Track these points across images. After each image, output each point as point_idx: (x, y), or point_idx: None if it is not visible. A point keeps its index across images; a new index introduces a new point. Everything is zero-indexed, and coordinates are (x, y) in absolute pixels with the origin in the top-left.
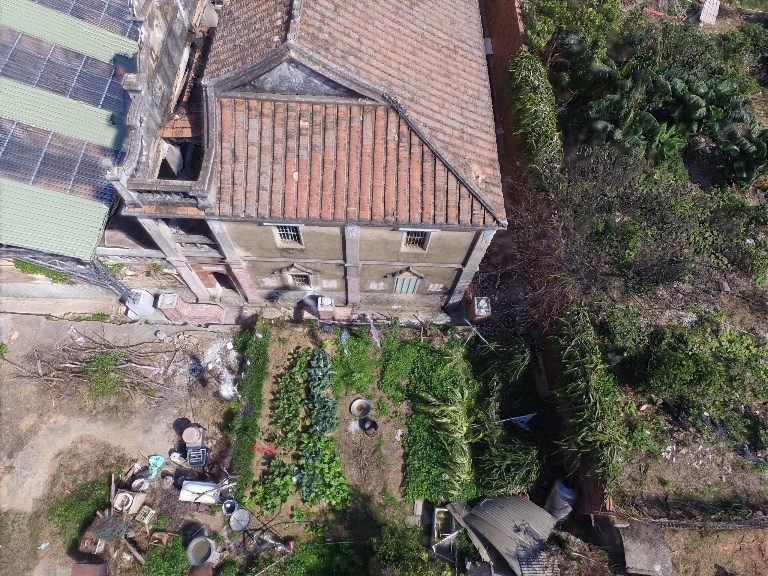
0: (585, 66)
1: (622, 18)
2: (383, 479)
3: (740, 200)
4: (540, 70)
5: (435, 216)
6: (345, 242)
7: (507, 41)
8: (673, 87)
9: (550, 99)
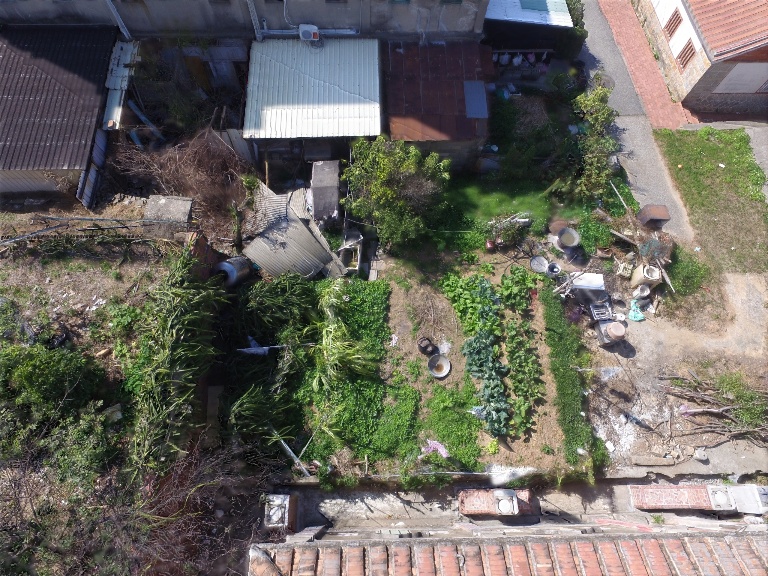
0: None
1: None
2: (409, 299)
3: None
4: None
5: (387, 559)
6: None
7: None
8: None
9: None
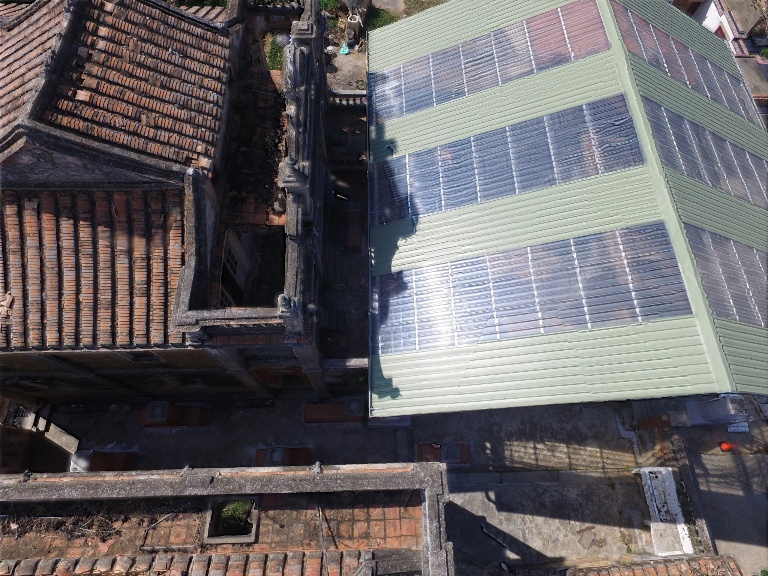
0: None
1: None
2: None
3: None
4: None
5: (27, 5)
6: None
7: None
8: None
9: None
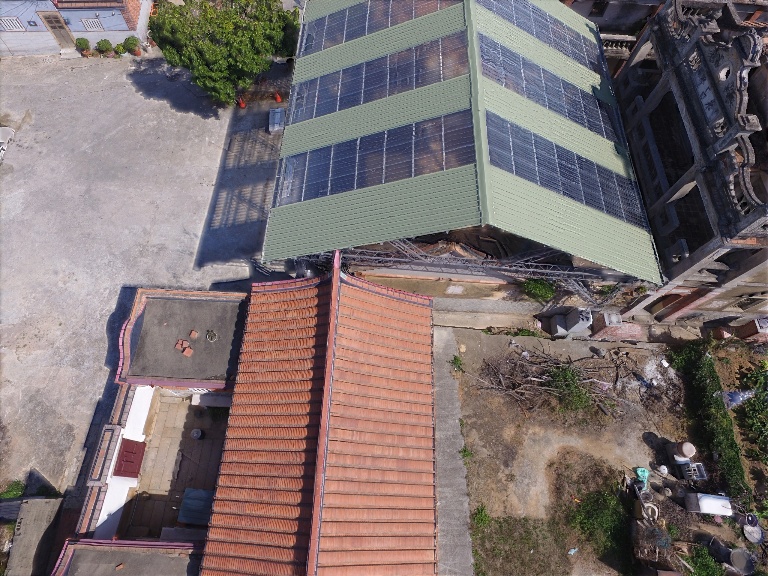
0: None
1: None
2: None
3: None
4: None
5: None
6: None
7: None
8: None
9: None
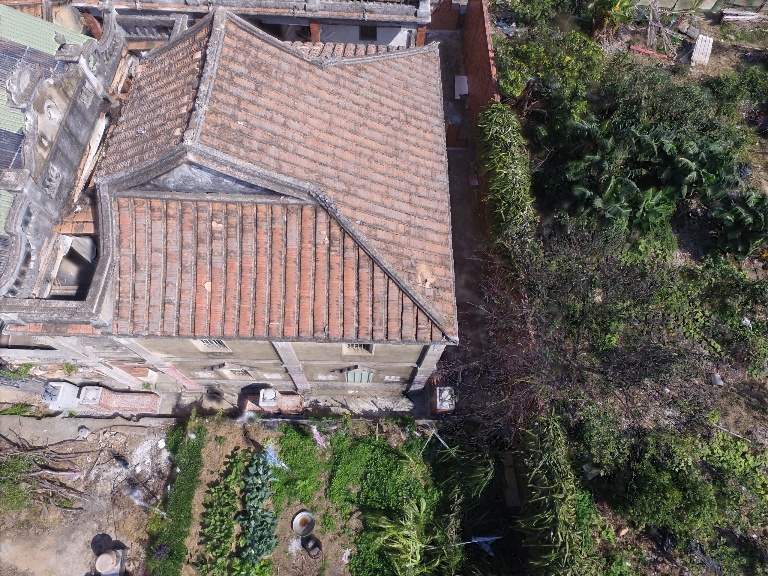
0: (563, 120)
1: (604, 64)
2: None
3: (734, 278)
4: (513, 125)
5: (373, 332)
6: (276, 349)
7: (481, 85)
8: (659, 148)
9: (523, 159)
